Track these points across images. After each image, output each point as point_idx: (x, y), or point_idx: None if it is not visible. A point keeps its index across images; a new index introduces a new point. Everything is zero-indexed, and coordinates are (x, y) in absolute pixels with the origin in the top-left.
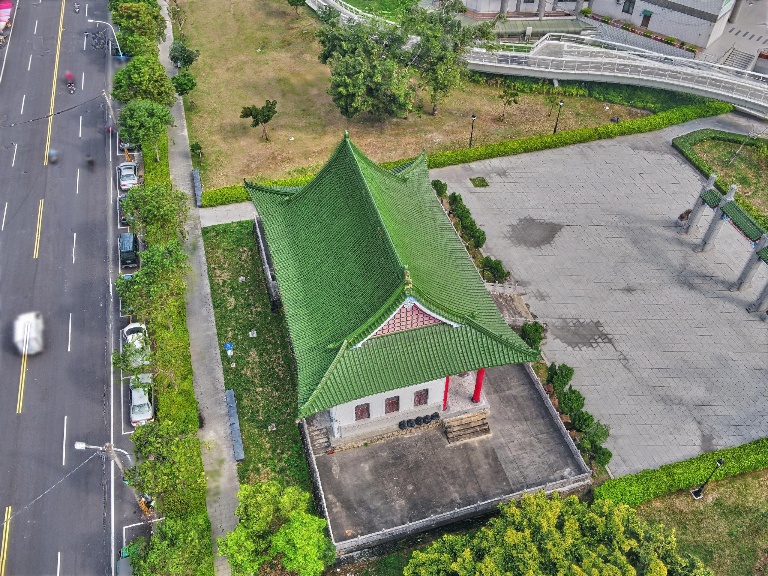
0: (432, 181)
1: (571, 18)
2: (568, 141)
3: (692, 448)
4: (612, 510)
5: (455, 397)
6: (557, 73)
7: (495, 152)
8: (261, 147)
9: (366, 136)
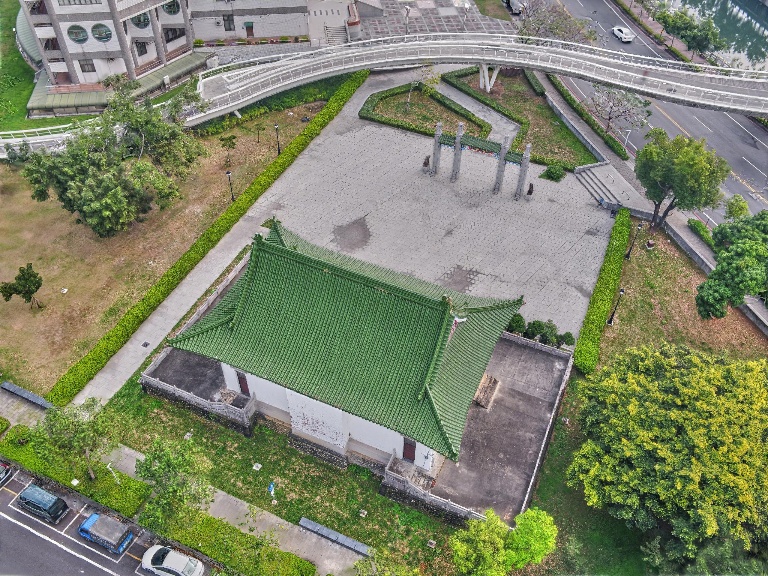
0: (252, 244)
1: (189, 53)
2: (296, 154)
3: (581, 300)
4: (646, 352)
5: None
6: (238, 104)
7: (257, 193)
8: (43, 318)
9: (133, 245)
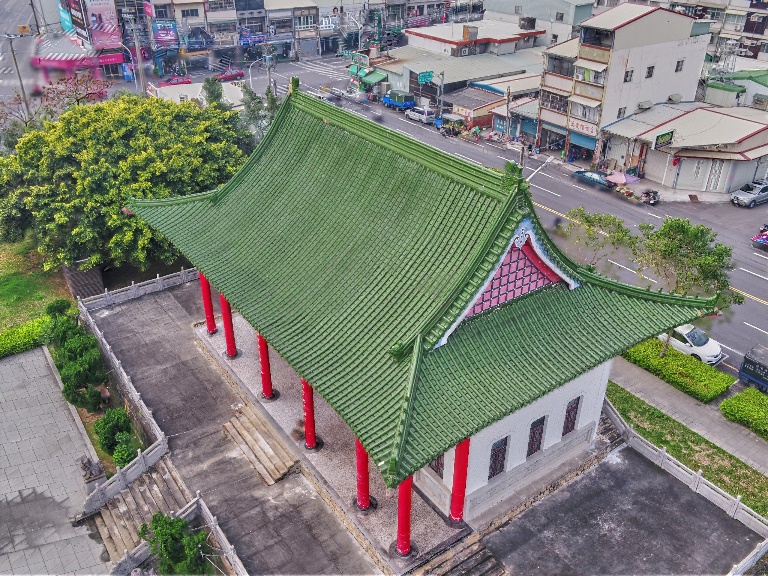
0: None
1: None
2: None
3: None
4: None
5: (240, 328)
6: None
7: None
8: None
9: None
